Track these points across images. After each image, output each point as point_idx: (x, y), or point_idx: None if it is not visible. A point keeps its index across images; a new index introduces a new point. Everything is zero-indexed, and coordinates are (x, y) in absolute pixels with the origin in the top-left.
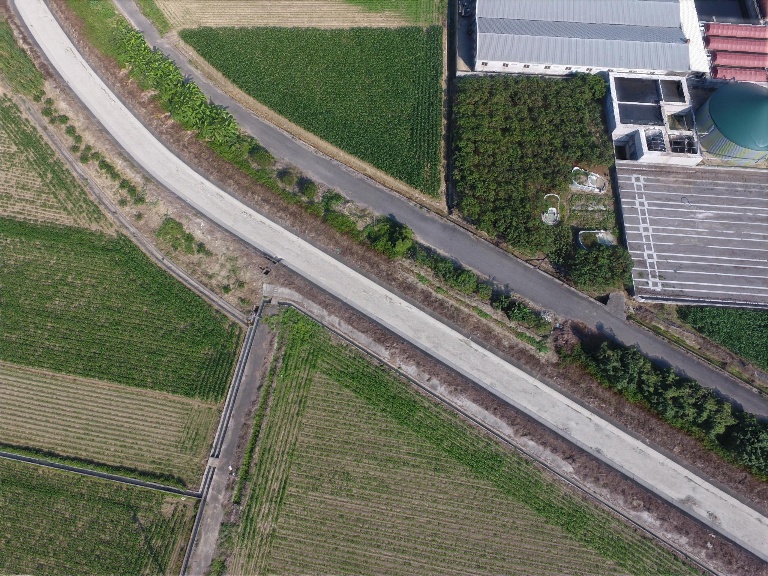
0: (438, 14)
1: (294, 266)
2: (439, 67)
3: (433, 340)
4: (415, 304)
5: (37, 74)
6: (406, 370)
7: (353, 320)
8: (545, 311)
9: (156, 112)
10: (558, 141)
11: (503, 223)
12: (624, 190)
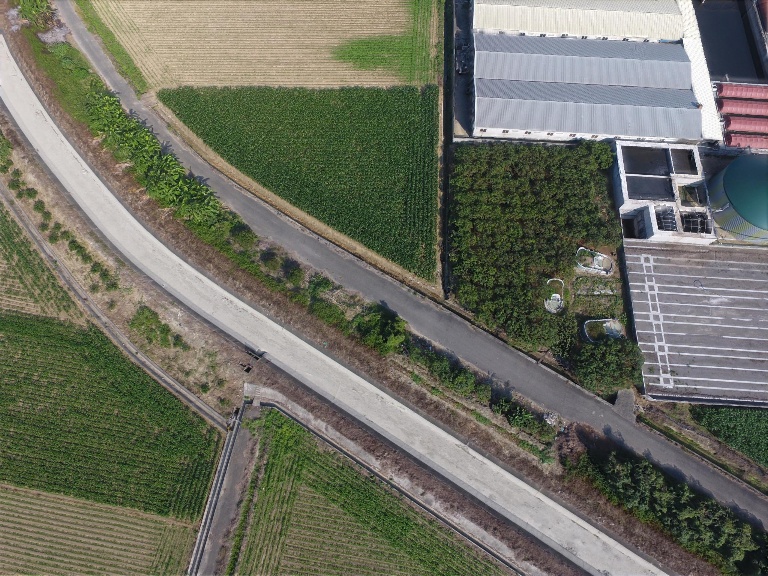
0: (434, 72)
1: (278, 360)
2: (435, 133)
3: (428, 445)
4: (408, 405)
5: (4, 142)
6: (398, 482)
7: (341, 425)
8: (548, 413)
9: (131, 186)
10: (562, 219)
11: (503, 313)
12: (633, 272)
